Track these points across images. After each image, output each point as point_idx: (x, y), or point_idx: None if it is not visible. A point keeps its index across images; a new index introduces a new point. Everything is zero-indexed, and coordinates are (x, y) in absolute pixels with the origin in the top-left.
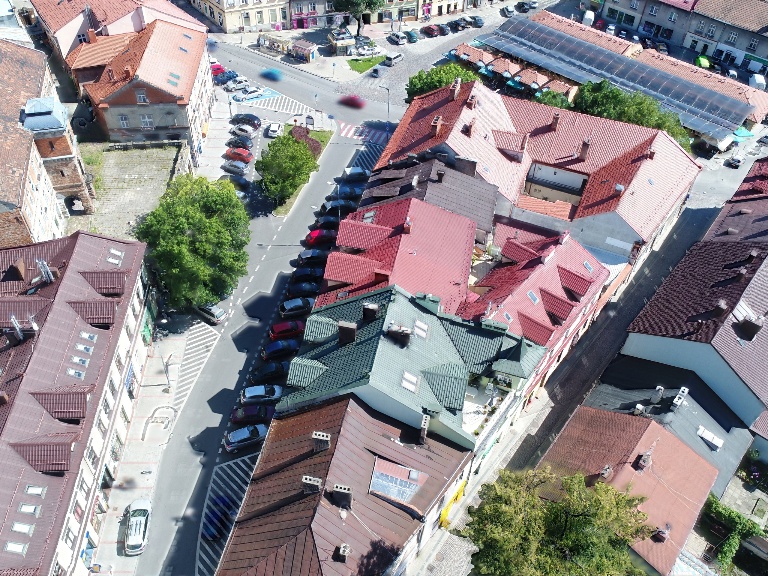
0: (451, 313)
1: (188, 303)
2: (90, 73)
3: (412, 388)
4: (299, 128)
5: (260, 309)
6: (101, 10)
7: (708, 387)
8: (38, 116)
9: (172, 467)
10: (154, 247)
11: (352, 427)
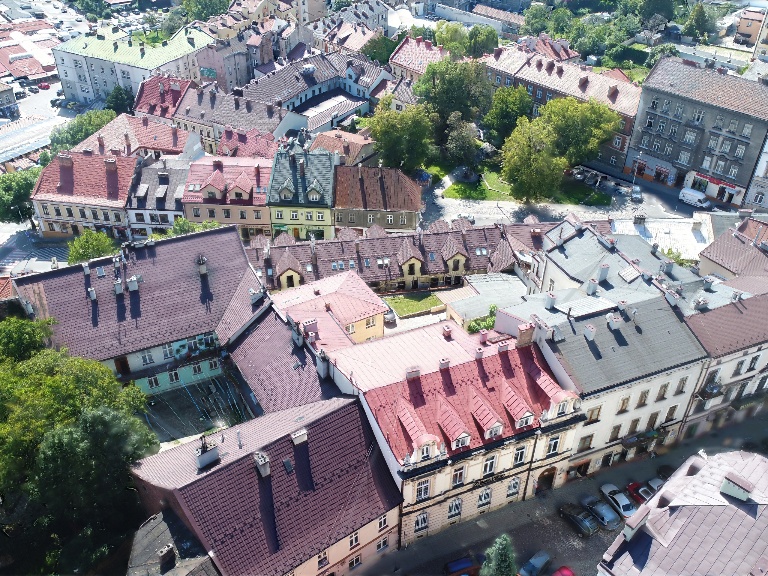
0: None
1: None
2: None
3: None
4: None
5: None
6: None
7: (295, 130)
8: None
9: None
10: None
11: None
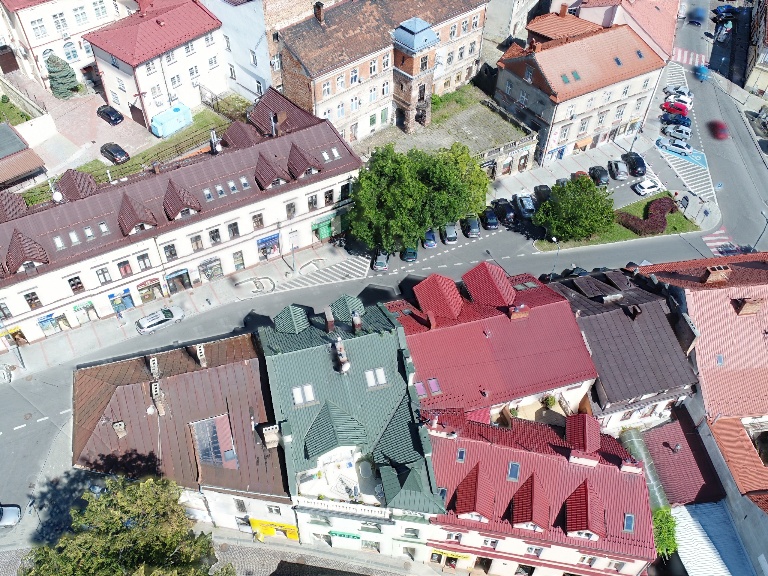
0: (439, 404)
1: None
2: (539, 39)
3: (299, 400)
4: (669, 201)
5: None
6: None
7: None
8: (406, 31)
9: (222, 314)
10: None
11: (234, 375)
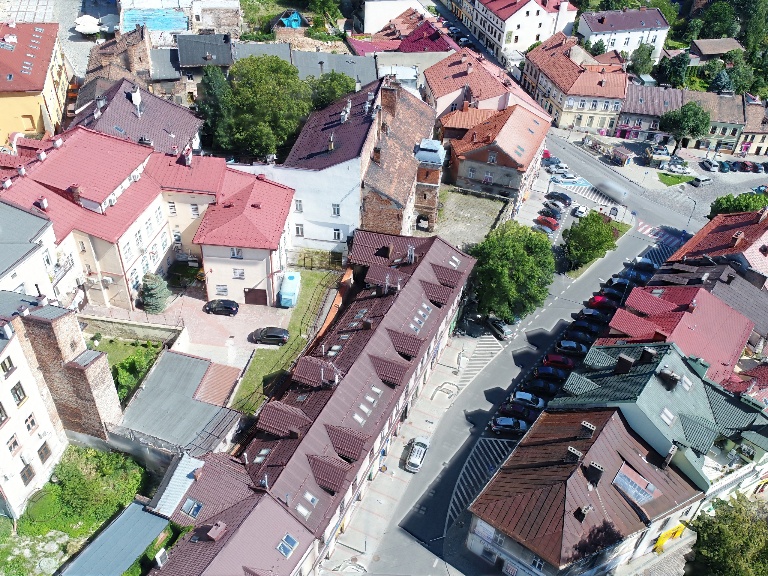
0: None
1: (484, 318)
2: (455, 132)
3: (668, 422)
4: (603, 215)
5: (539, 340)
6: (477, 89)
7: None
8: (427, 151)
9: (448, 426)
10: (480, 265)
11: (612, 431)
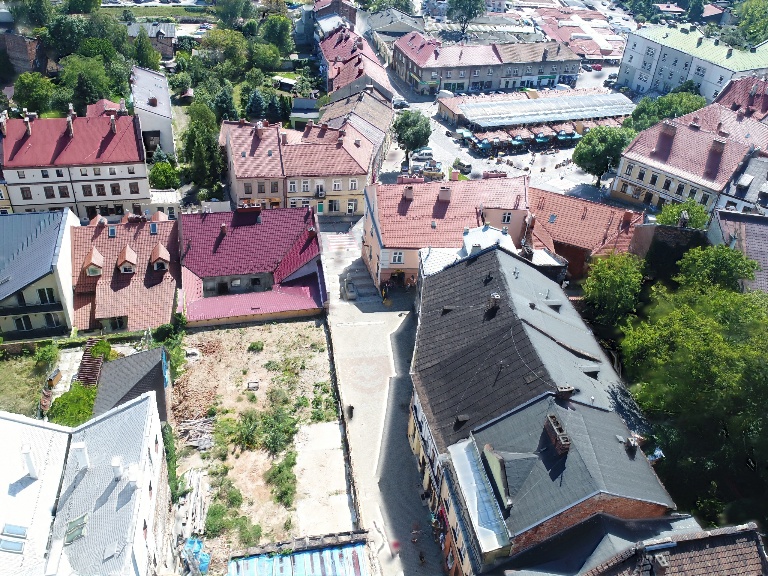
0: None
1: None
2: None
3: None
4: None
5: None
6: (496, 202)
7: None
8: None
9: None
10: None
11: None
